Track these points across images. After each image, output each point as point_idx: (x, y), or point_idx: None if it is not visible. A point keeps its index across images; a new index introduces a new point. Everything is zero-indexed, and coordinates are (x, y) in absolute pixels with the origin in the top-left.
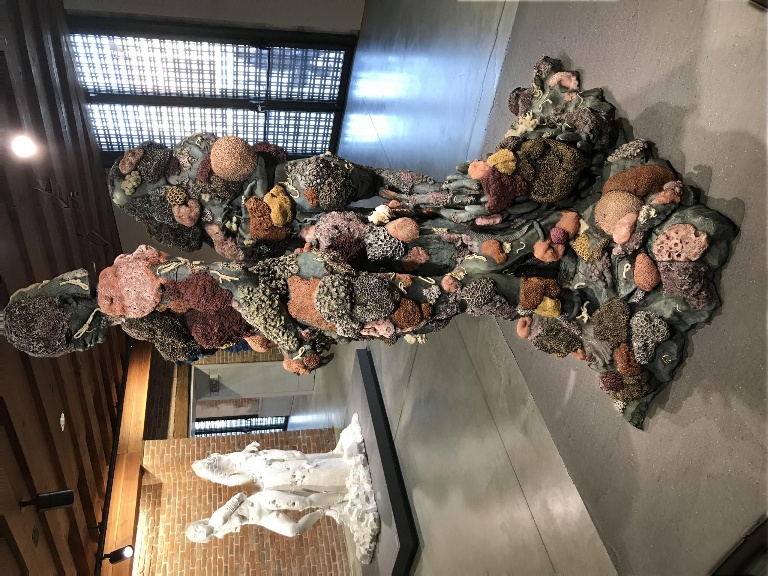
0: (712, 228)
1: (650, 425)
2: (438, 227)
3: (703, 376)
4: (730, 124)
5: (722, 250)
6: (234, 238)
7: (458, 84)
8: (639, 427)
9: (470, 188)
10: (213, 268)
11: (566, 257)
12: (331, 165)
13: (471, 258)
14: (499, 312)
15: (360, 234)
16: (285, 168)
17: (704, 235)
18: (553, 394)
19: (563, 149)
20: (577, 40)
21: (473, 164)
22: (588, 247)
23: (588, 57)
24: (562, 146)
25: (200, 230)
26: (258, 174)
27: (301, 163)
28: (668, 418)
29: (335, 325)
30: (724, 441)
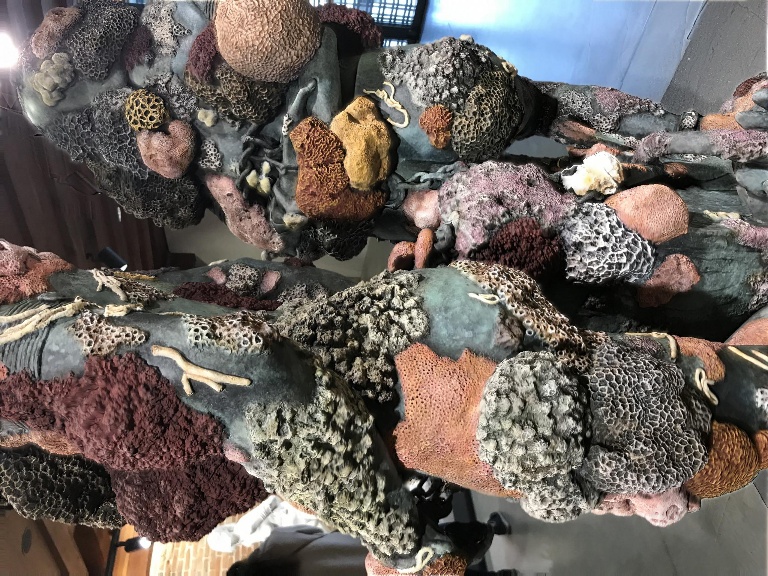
0: None
1: None
2: (712, 209)
3: None
4: None
5: None
6: (264, 206)
7: None
8: None
9: None
10: (164, 338)
11: None
12: (480, 58)
13: None
14: None
15: (554, 219)
16: (379, 61)
17: None
18: None
19: None
20: None
21: None
22: None
23: None
24: None
25: (196, 186)
26: (321, 67)
27: (416, 50)
28: None
29: (524, 493)
30: None
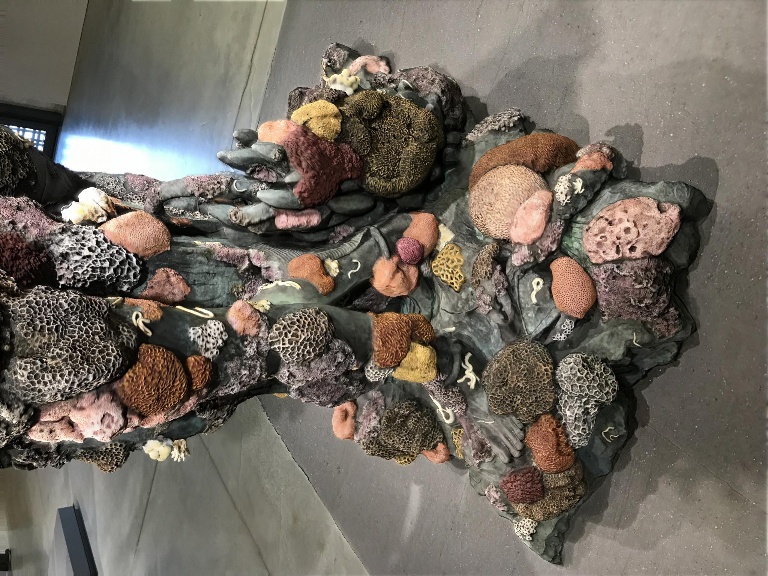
0: (686, 195)
1: (575, 555)
2: (203, 241)
3: (675, 455)
4: (666, 54)
5: (691, 238)
6: None
7: (199, 136)
8: (557, 562)
9: (263, 162)
10: None
11: (418, 289)
12: None
13: (271, 286)
14: (315, 391)
15: (41, 234)
16: None
17: (676, 207)
18: (381, 528)
19: (411, 108)
20: (381, 18)
21: (266, 123)
22: (461, 263)
23: (401, 34)
24: (409, 103)
25: None
26: None
27: None
28: (611, 538)
29: None
30: (741, 564)
